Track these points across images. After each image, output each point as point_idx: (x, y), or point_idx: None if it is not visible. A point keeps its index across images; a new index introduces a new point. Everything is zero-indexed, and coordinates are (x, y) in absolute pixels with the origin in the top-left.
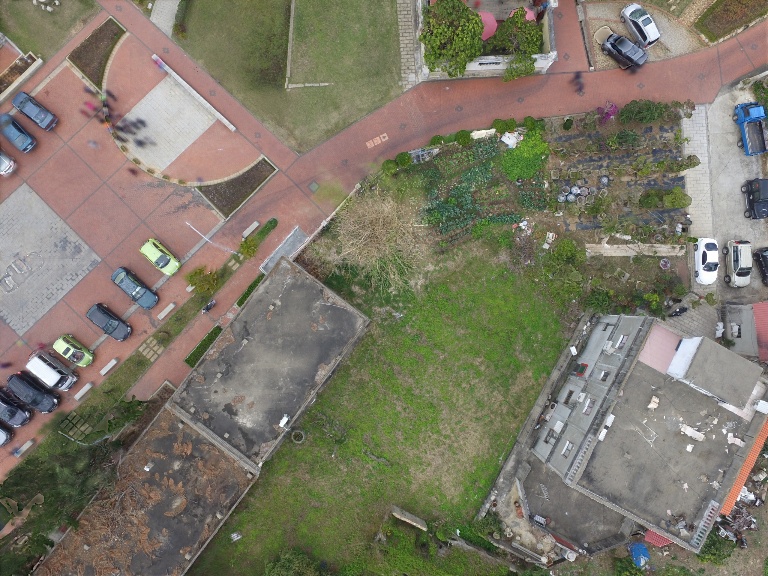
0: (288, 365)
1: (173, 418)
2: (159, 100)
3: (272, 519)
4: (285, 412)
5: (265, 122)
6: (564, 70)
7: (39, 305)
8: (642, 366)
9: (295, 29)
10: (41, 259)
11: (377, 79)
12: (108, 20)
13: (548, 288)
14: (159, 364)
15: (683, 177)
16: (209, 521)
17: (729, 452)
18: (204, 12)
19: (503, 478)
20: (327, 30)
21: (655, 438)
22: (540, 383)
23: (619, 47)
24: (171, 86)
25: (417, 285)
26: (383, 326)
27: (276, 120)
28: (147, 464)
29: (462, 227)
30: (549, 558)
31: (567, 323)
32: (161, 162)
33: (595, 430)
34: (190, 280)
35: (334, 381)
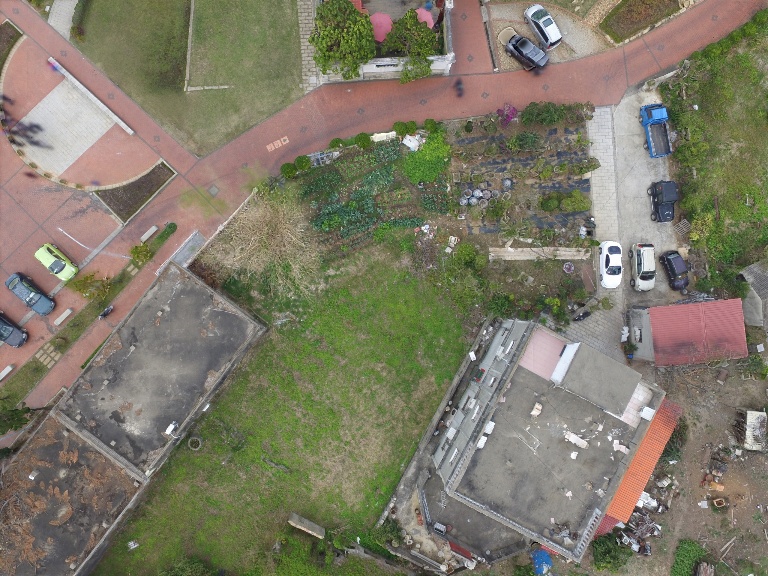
0: (177, 372)
1: (59, 426)
2: (56, 104)
3: (170, 527)
4: (174, 419)
5: (164, 125)
6: (468, 72)
7: None
8: (525, 372)
9: (194, 31)
10: None
11: (277, 81)
12: (4, 23)
13: (450, 292)
14: (56, 370)
15: (588, 180)
16: (95, 530)
17: (615, 459)
18: (103, 14)
19: (404, 485)
20: (226, 32)
21: (538, 445)
22: (443, 389)
23: (520, 48)
24: (69, 89)
25: (317, 290)
26: (283, 331)
27: (175, 123)
28: (31, 472)
29: (363, 231)
30: (450, 566)
31: (470, 328)
32: (58, 166)
33: (475, 438)
34: None
35: (233, 387)
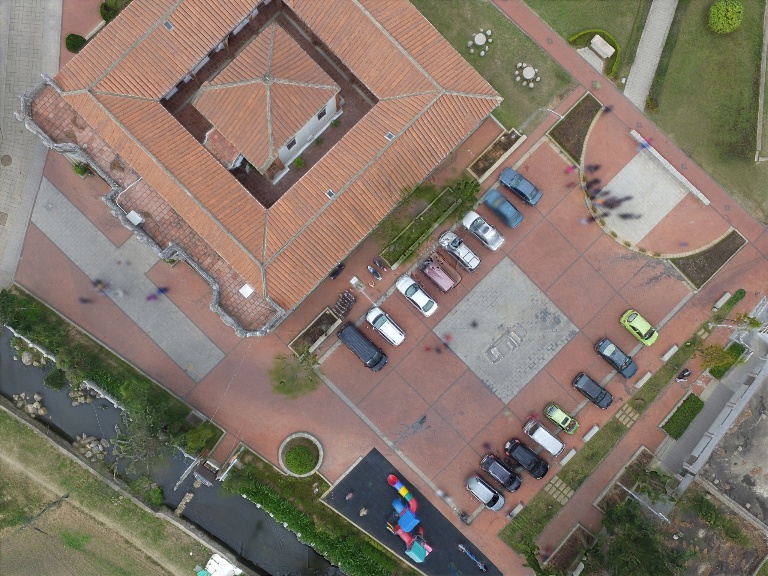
0: None
1: (698, 489)
2: (634, 174)
3: None
4: None
5: (734, 195)
6: None
7: (522, 374)
8: None
9: (766, 103)
10: (524, 330)
11: None
12: (587, 96)
13: None
14: (635, 430)
15: None
16: None
17: None
18: (675, 86)
19: None
20: None
21: None
22: None
23: None
24: (645, 160)
25: None
26: None
27: (744, 192)
28: (679, 533)
29: None
30: None
31: None
32: (636, 235)
33: None
34: (715, 358)
35: None
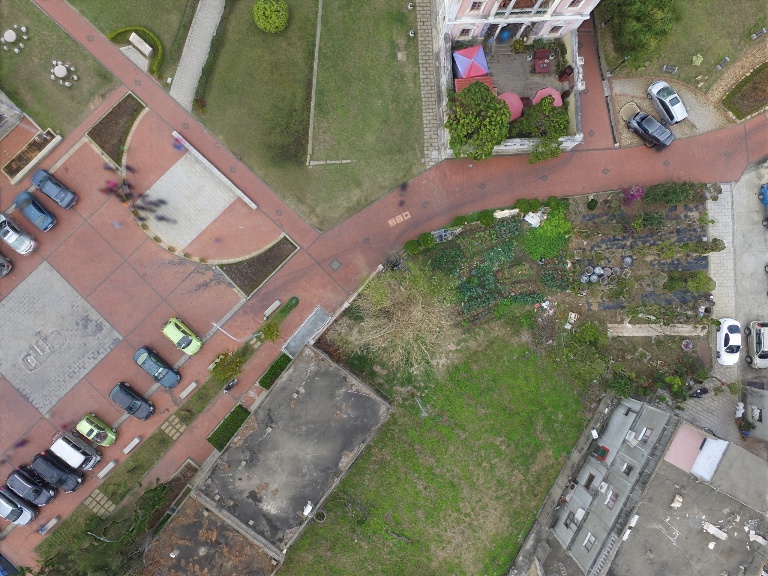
0: (312, 452)
1: (198, 505)
2: (179, 177)
3: None
4: (309, 499)
5: (286, 199)
6: (589, 147)
7: (61, 384)
8: (666, 465)
9: (317, 105)
10: (63, 338)
11: (400, 156)
12: (127, 95)
13: (569, 368)
14: (181, 442)
15: (707, 256)
16: None
17: (750, 549)
18: (224, 87)
19: (522, 556)
20: (349, 106)
21: (677, 536)
22: (560, 462)
23: (646, 126)
24: (191, 163)
25: (439, 365)
26: (404, 406)
27: (297, 197)
28: (173, 552)
29: (484, 306)
30: None
31: (588, 403)
32: (182, 240)
33: (619, 530)
34: (214, 369)
35: None
